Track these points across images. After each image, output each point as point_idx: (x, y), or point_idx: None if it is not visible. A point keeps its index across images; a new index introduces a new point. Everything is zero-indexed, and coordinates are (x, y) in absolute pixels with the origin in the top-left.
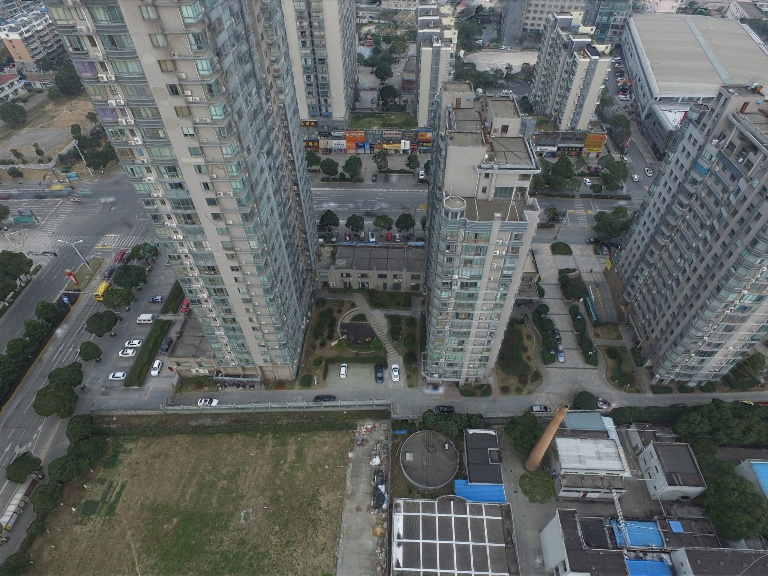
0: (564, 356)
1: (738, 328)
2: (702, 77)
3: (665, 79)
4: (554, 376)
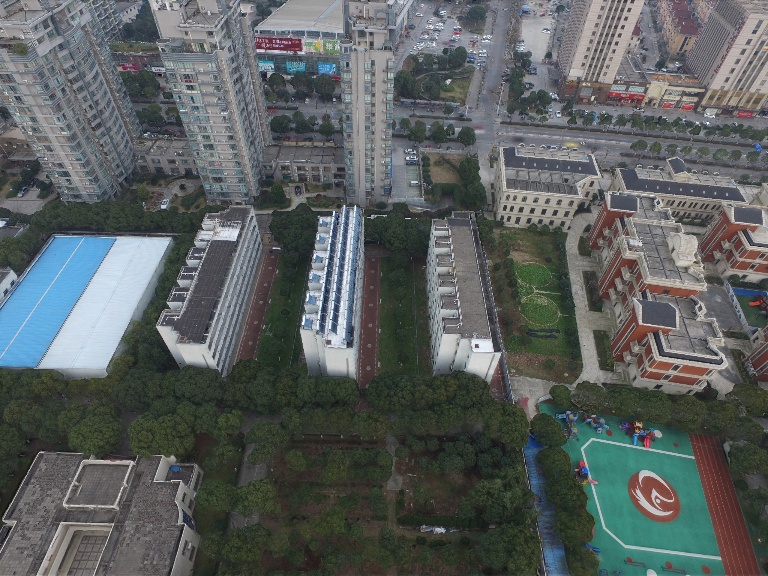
0: (26, 194)
1: (55, 148)
2: (306, 16)
3: (276, 17)
4: (5, 204)
